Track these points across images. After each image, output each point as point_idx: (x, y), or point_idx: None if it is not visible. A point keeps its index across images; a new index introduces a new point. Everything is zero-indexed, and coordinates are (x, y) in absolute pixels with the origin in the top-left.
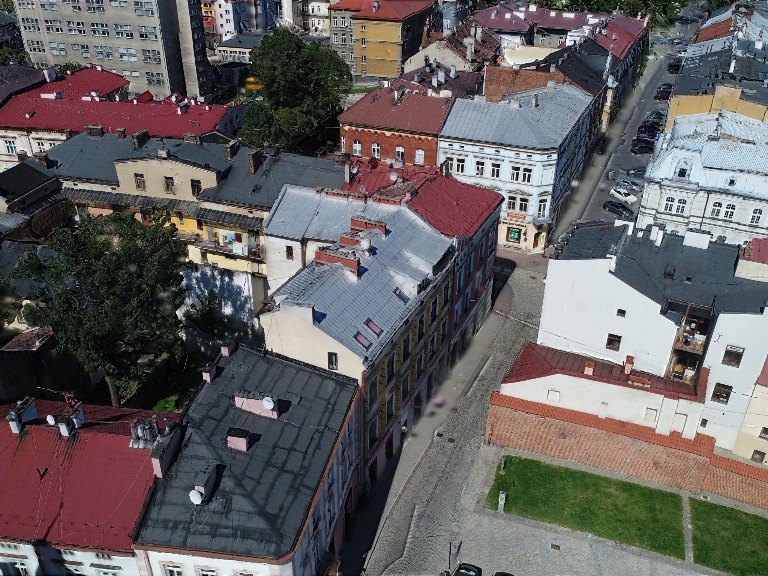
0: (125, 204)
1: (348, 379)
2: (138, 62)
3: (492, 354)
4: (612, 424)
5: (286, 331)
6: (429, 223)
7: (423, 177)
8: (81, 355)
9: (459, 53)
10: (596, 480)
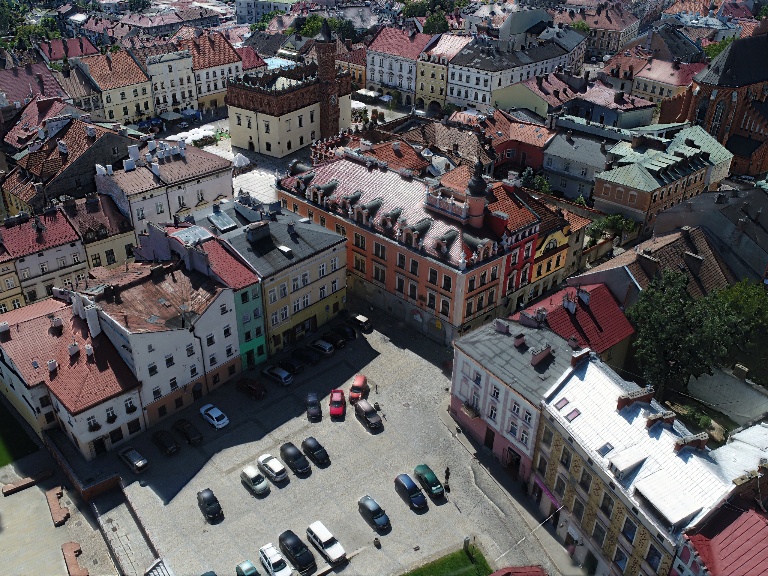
0: None
1: None
2: None
3: None
4: None
5: None
6: None
7: None
8: None
9: None
10: None
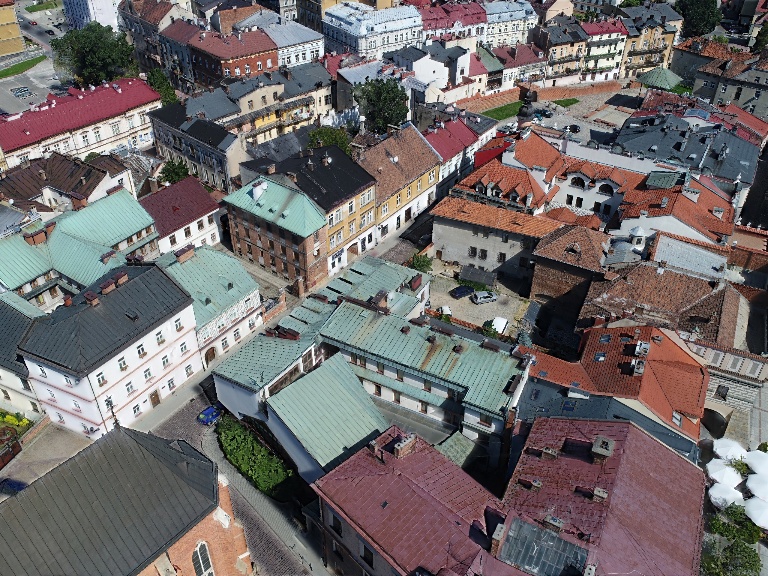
0: None
1: None
2: None
3: None
4: (460, 102)
5: None
6: None
7: None
8: None
9: None
10: None
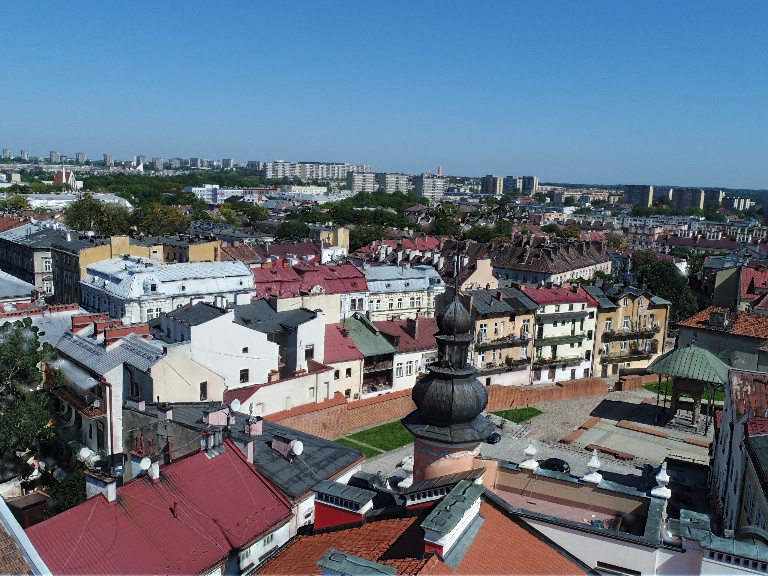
0: None
1: (215, 404)
2: None
3: None
4: (297, 410)
5: (171, 375)
6: None
7: None
8: None
9: None
10: None
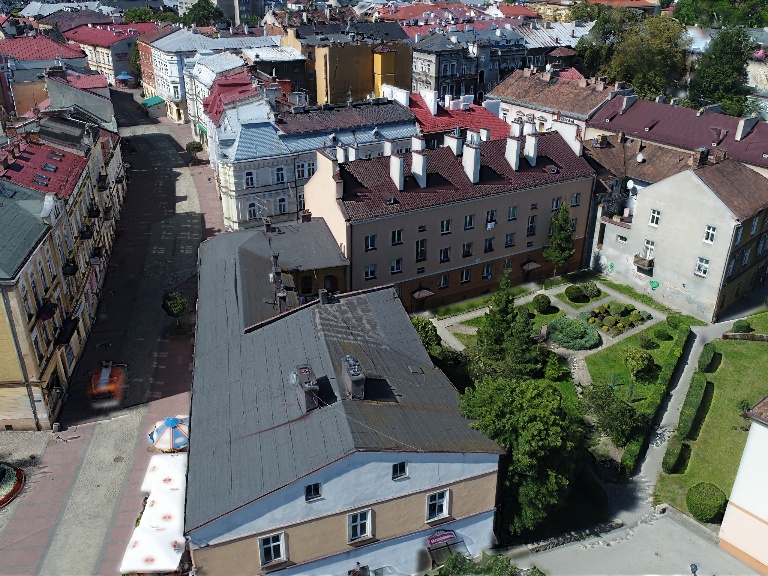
0: None
1: None
2: None
3: None
4: None
5: None
6: None
7: None
8: None
9: (285, 20)
10: None
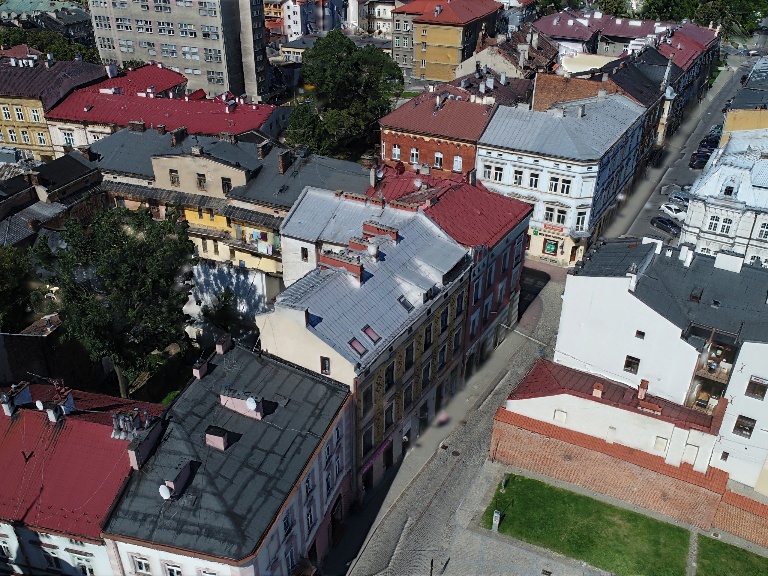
0: (159, 198)
1: (340, 385)
2: (200, 60)
3: (511, 368)
4: (619, 450)
5: (280, 333)
6: (446, 231)
7: (447, 184)
8: (87, 344)
9: (511, 59)
10: (600, 507)
